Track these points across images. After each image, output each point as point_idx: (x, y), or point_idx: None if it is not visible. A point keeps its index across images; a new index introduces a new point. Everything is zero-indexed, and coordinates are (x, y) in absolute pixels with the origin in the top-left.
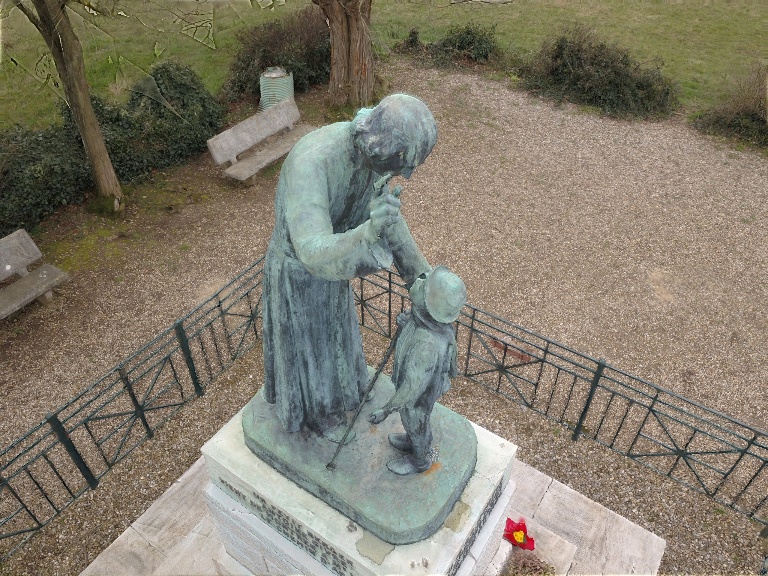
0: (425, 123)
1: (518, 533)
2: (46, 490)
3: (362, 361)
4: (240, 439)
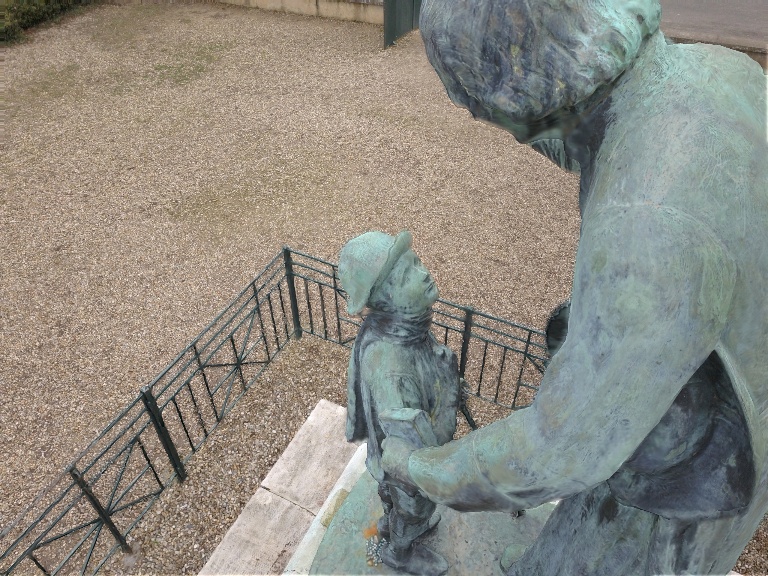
0: None
1: None
2: None
3: None
4: None
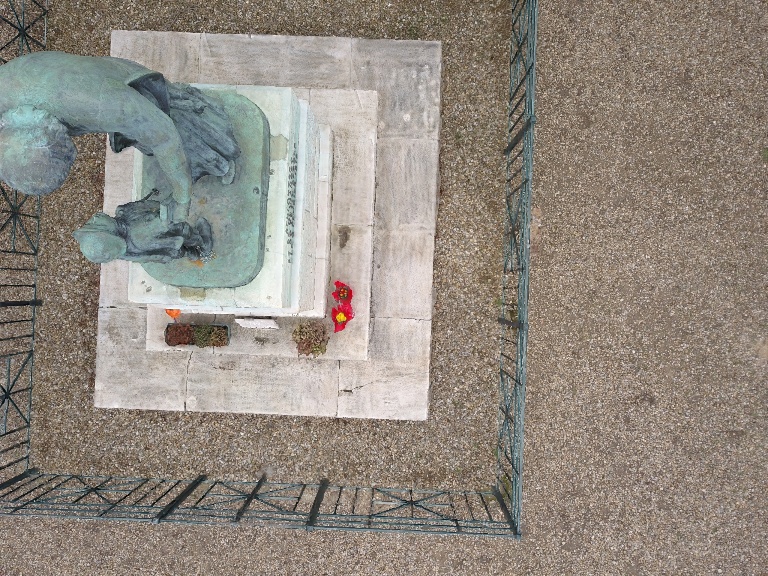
0: (14, 184)
1: (343, 316)
2: None
3: (209, 166)
4: None
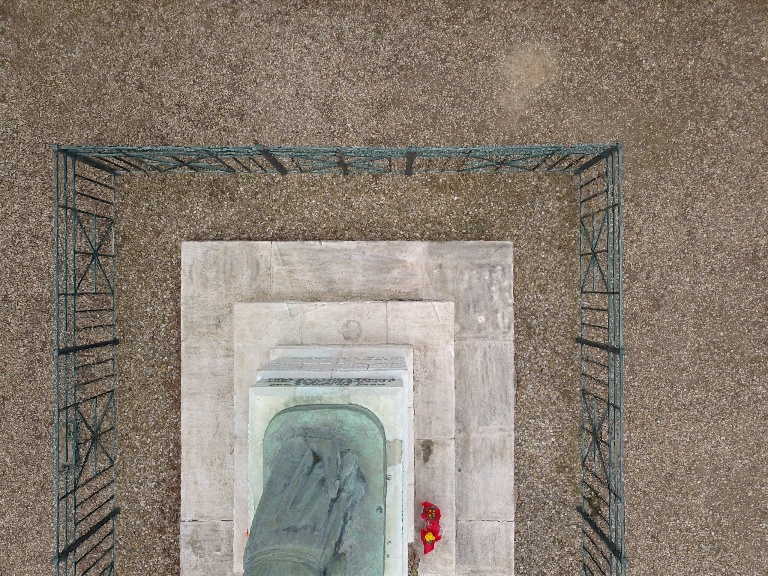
0: None
1: (432, 536)
2: (259, 139)
3: None
4: (271, 415)
